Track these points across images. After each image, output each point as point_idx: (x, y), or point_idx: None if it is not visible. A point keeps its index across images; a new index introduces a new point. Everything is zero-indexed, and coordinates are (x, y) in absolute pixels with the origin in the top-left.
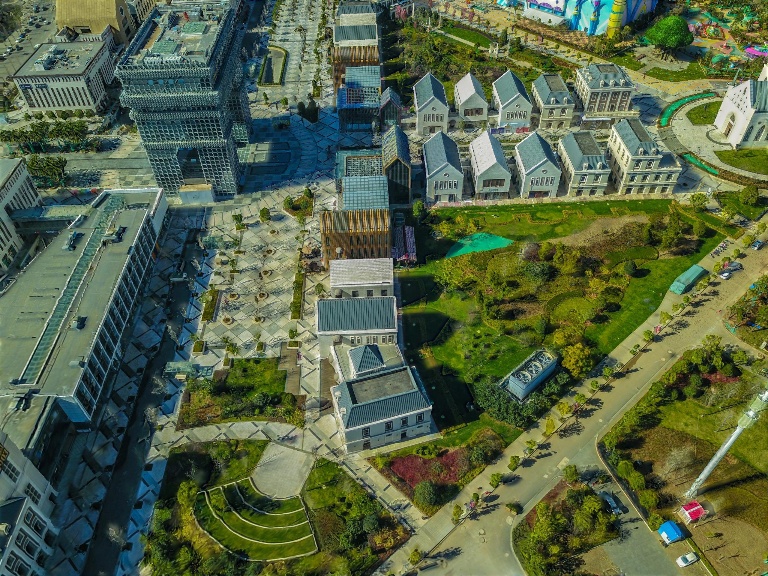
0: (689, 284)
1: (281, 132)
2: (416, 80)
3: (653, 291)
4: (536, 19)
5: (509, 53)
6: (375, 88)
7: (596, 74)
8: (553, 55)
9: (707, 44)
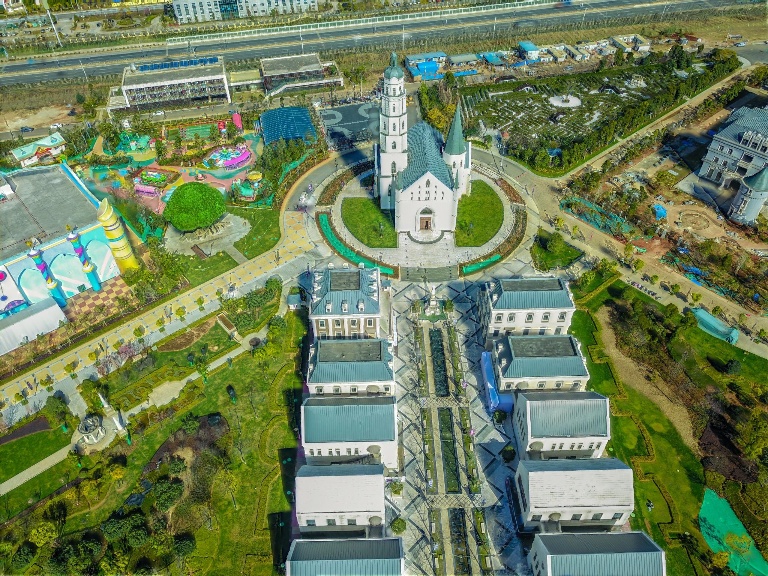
0: (726, 326)
1: None
2: None
3: (744, 358)
4: (23, 342)
5: (115, 409)
6: None
7: (355, 296)
8: (148, 346)
9: None
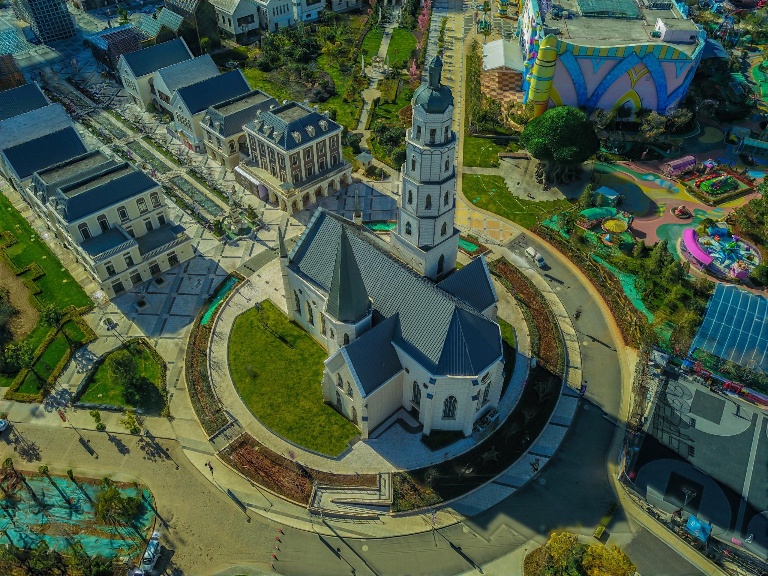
0: None
1: (78, 47)
2: (248, 58)
3: None
4: (482, 54)
5: (385, 76)
6: (149, 36)
7: None
8: None
9: (663, 194)
